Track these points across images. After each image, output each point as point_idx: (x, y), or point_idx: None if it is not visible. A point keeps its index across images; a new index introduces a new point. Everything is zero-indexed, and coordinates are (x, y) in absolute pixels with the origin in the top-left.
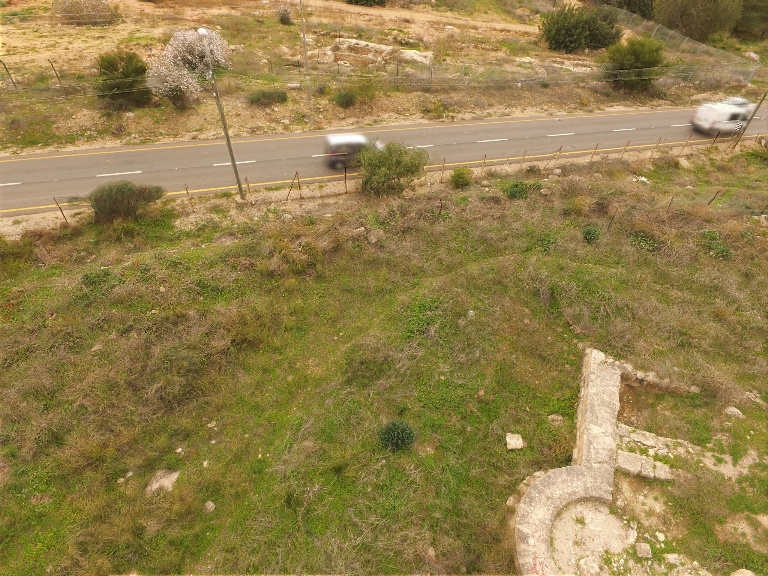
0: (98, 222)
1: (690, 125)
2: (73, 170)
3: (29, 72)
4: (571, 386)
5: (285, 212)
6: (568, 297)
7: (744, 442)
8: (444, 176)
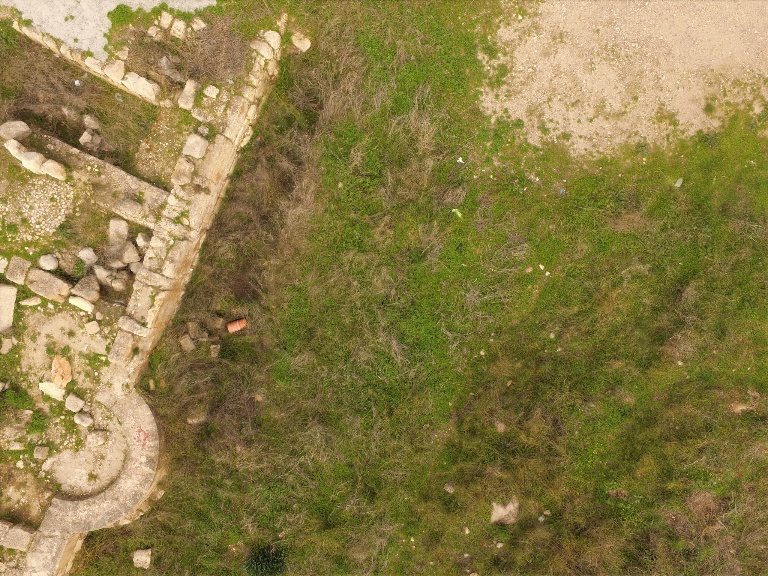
0: None
1: None
2: None
3: None
4: None
5: None
6: None
7: None
8: None
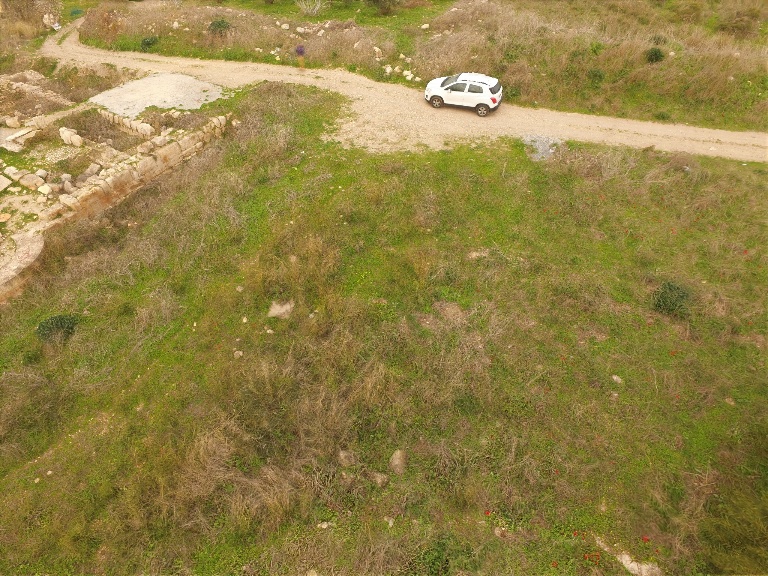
0: None
1: None
2: None
3: None
4: None
5: None
6: None
7: None
8: None
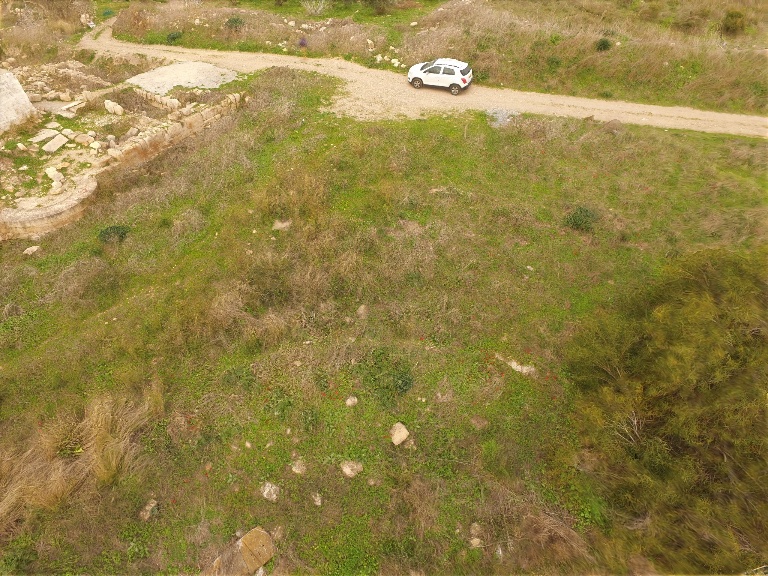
0: None
1: None
2: None
3: None
4: None
5: None
6: None
7: None
8: None
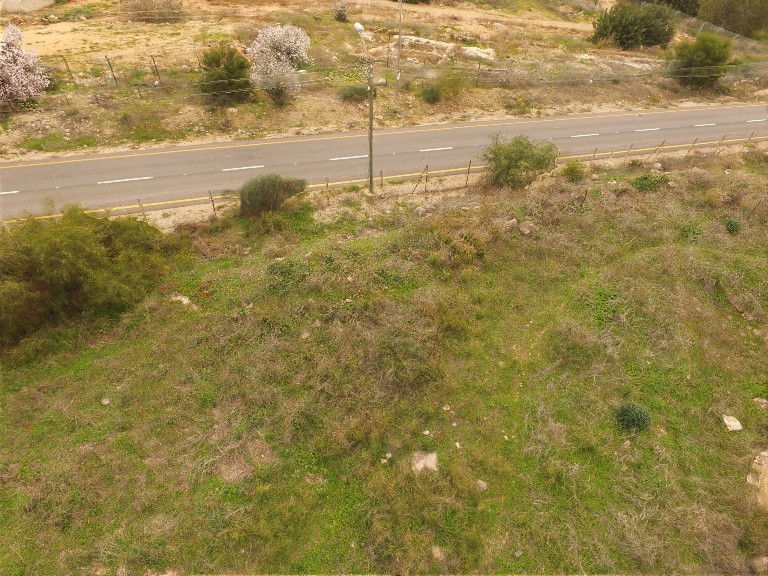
0: (243, 215)
1: (765, 120)
2: (198, 164)
3: (122, 68)
4: (764, 371)
5: (414, 205)
6: (731, 286)
7: None
8: None
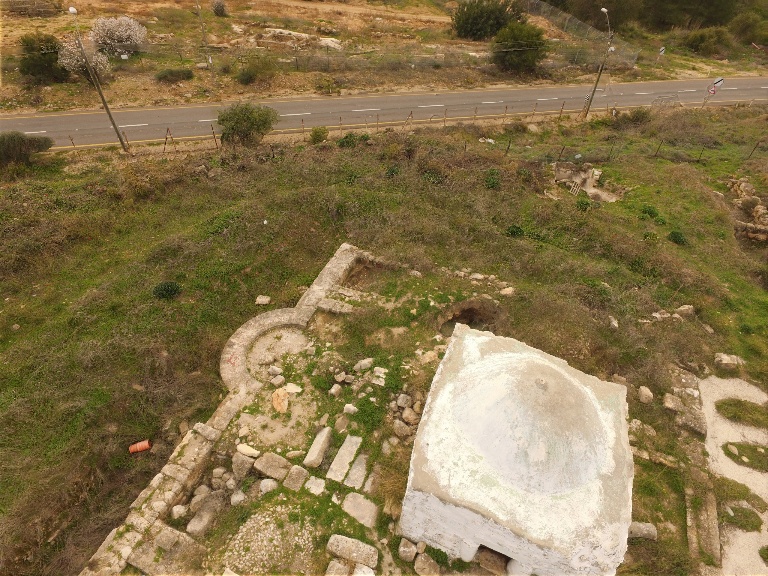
0: None
1: (556, 99)
2: None
3: None
4: None
5: None
6: (352, 214)
7: (408, 289)
8: (308, 136)
